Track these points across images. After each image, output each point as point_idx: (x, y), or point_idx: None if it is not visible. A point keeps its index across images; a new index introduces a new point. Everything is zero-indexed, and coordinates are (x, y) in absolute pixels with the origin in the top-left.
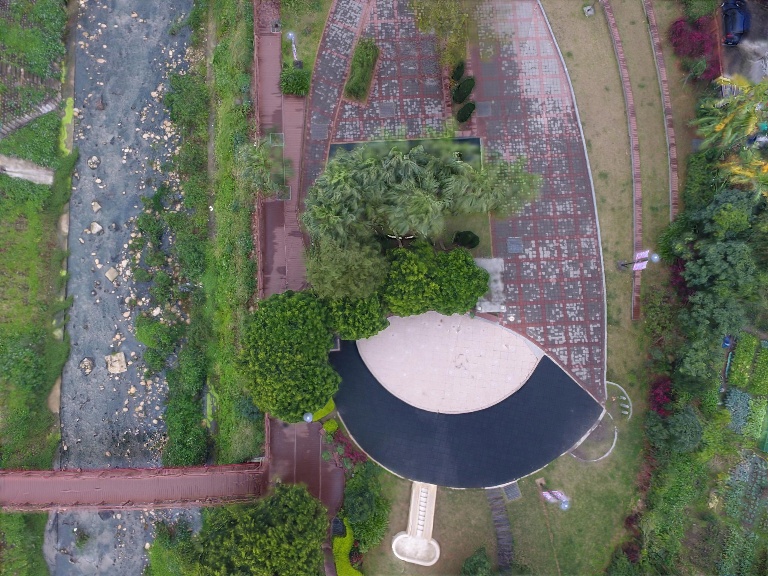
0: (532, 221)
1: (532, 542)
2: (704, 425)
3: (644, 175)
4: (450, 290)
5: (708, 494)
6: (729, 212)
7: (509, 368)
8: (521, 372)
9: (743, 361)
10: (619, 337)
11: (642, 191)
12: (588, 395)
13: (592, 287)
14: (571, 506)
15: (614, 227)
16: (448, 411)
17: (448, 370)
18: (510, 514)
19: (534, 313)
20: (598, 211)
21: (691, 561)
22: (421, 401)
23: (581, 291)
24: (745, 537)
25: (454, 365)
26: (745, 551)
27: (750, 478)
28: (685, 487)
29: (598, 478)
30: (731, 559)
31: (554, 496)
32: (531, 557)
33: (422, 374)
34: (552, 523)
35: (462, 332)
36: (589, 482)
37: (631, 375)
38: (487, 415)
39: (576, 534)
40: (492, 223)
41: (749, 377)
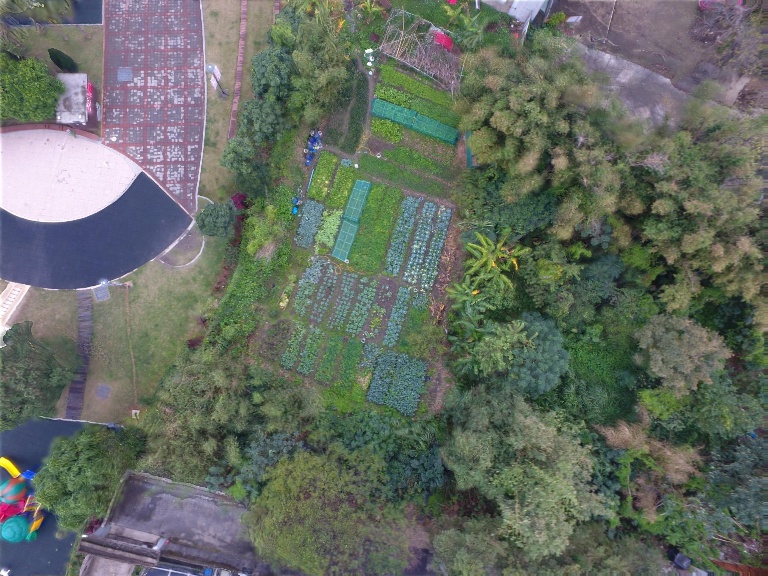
0: (143, 54)
1: (110, 335)
2: (257, 222)
3: (250, 13)
4: (14, 92)
5: (280, 295)
6: (276, 25)
7: (108, 183)
8: (119, 186)
9: (322, 177)
10: (214, 157)
11: (247, 27)
12: (179, 207)
13: (194, 113)
14: (151, 304)
15: (219, 59)
16: (47, 220)
17: (50, 184)
18: (95, 311)
19: (136, 134)
20: (205, 45)
21: (261, 355)
22: (23, 211)
23: (183, 116)
24: (312, 334)
25: (56, 179)
26: (310, 346)
27: (322, 282)
28: (250, 284)
29: (181, 280)
30: (296, 353)
31: (113, 284)
32: (107, 348)
33: (26, 187)
34: (131, 318)
35: (66, 150)
36: (172, 284)
37: (221, 190)
38: (83, 224)
39: (152, 328)
40: (105, 55)
41: (329, 192)
